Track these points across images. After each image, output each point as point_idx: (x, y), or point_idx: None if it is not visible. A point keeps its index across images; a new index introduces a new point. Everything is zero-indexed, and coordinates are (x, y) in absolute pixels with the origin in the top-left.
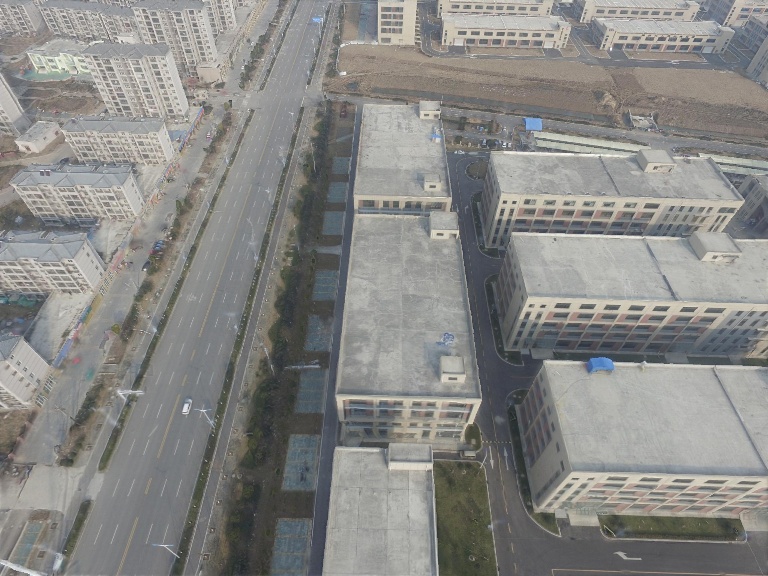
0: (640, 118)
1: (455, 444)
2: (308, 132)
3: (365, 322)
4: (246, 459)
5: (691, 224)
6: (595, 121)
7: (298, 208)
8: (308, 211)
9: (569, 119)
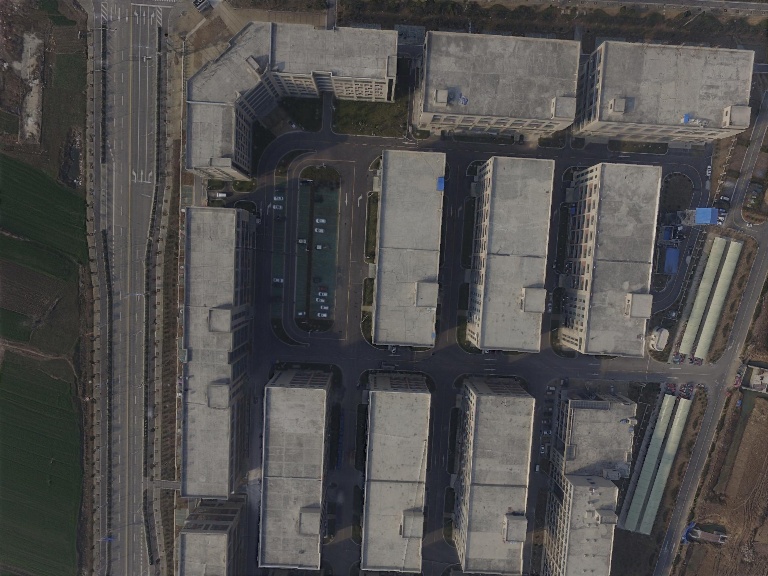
0: (765, 379)
1: (416, 123)
2: (758, 13)
3: (478, 49)
4: (412, 2)
5: (575, 321)
6: (761, 328)
7: (624, 10)
8: (624, 21)
9: (766, 300)
